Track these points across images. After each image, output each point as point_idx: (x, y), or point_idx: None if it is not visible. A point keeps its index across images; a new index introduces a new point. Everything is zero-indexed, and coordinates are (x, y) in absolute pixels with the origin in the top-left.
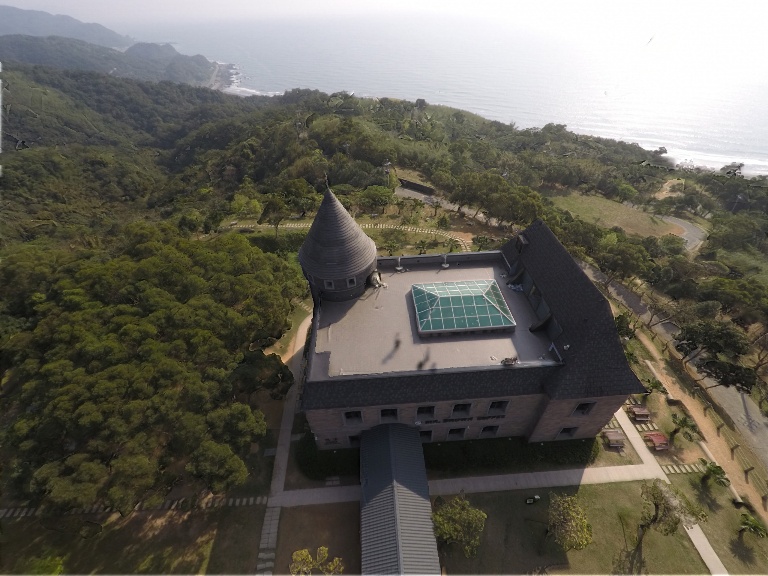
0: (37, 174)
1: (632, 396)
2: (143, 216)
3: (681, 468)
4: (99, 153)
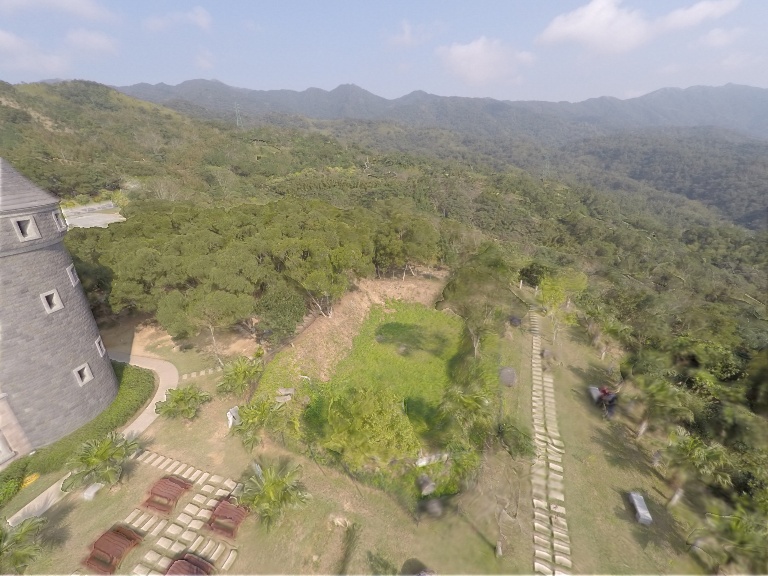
0: None
1: None
2: (586, 265)
3: None
4: None
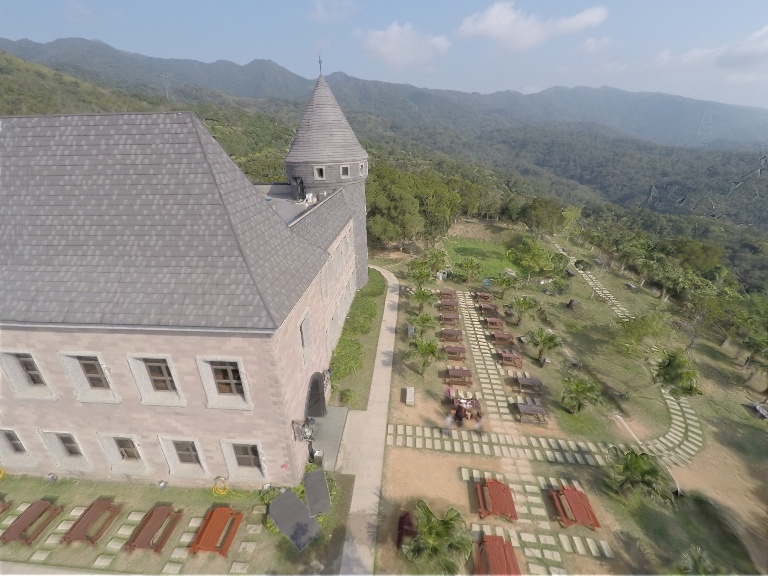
0: (681, 231)
1: None
2: None
3: None
4: (766, 241)
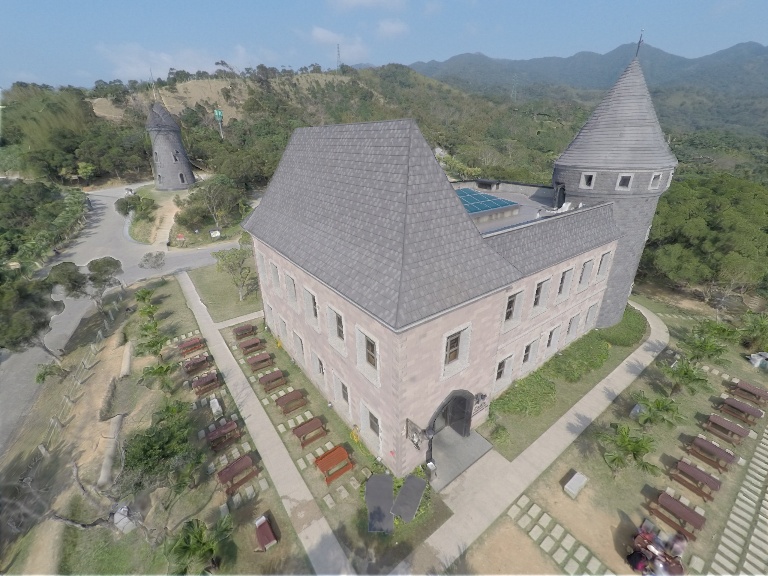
0: None
1: (191, 389)
2: None
3: (177, 339)
4: None
